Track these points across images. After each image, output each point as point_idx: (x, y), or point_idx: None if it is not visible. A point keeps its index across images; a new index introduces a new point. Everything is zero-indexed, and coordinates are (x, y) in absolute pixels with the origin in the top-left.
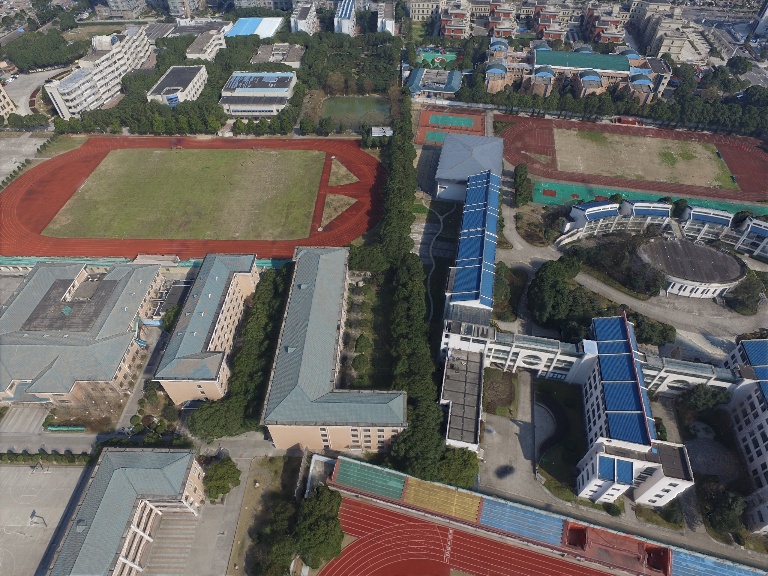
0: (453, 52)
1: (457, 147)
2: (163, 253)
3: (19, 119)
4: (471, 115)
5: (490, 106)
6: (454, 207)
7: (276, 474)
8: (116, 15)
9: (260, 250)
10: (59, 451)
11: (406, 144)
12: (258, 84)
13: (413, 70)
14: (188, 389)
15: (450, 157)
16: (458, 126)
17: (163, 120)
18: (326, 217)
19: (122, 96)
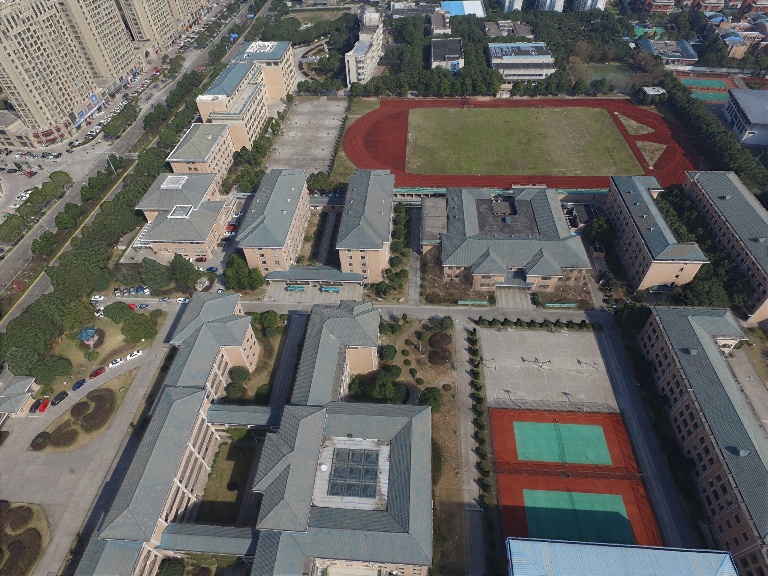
0: (659, 27)
1: (753, 99)
2: None
3: (320, 84)
4: (719, 78)
5: (733, 70)
6: (762, 150)
7: (762, 339)
8: (321, 2)
9: None
10: (562, 321)
11: (696, 98)
12: (520, 52)
13: (640, 41)
14: (668, 273)
15: (753, 107)
16: (714, 87)
17: (449, 83)
18: (649, 159)
19: (380, 67)
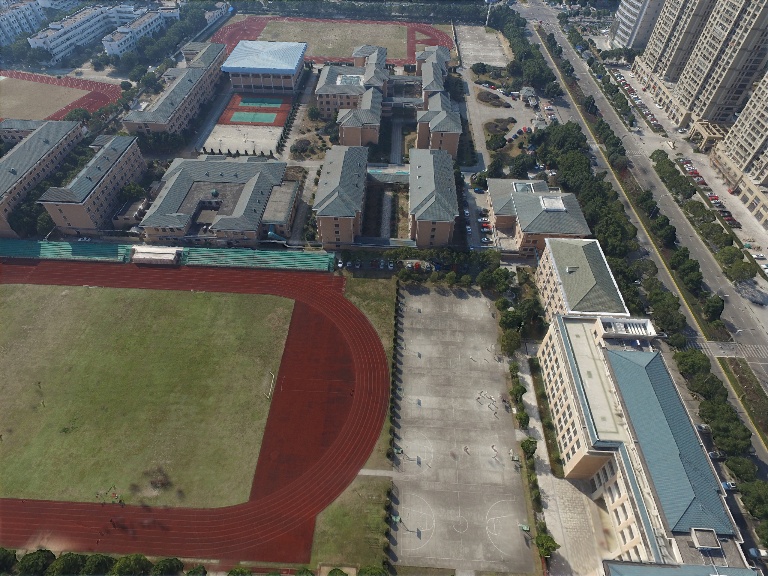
0: None
1: None
2: (152, 272)
3: None
4: None
5: None
6: None
7: None
8: None
9: (47, 272)
10: None
11: None
12: None
13: None
14: None
15: None
16: None
17: (110, 573)
18: None
19: None
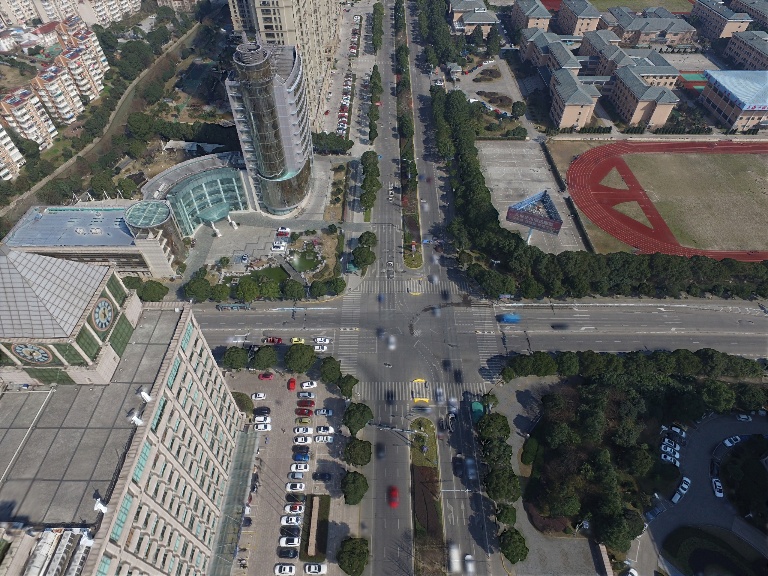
0: None
1: None
2: None
3: None
4: None
5: None
6: None
7: None
8: None
9: None
10: None
11: None
12: None
13: None
14: (733, 29)
15: None
16: None
17: None
18: None
19: None
